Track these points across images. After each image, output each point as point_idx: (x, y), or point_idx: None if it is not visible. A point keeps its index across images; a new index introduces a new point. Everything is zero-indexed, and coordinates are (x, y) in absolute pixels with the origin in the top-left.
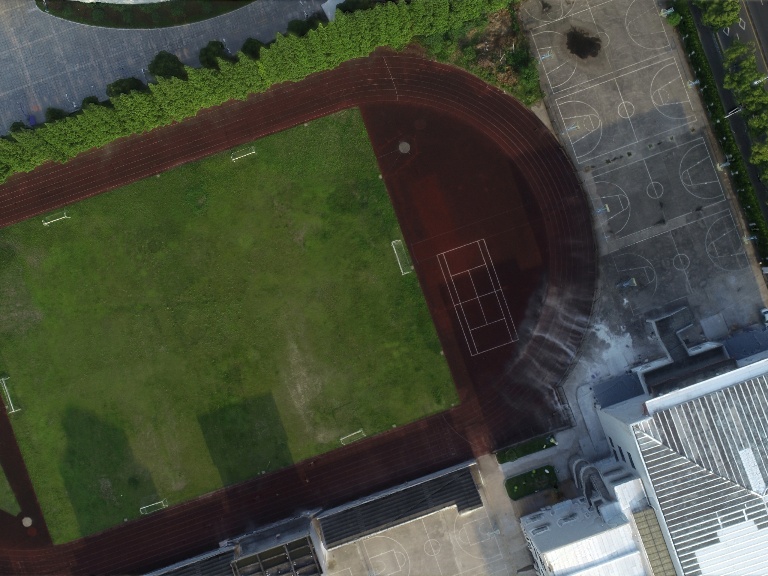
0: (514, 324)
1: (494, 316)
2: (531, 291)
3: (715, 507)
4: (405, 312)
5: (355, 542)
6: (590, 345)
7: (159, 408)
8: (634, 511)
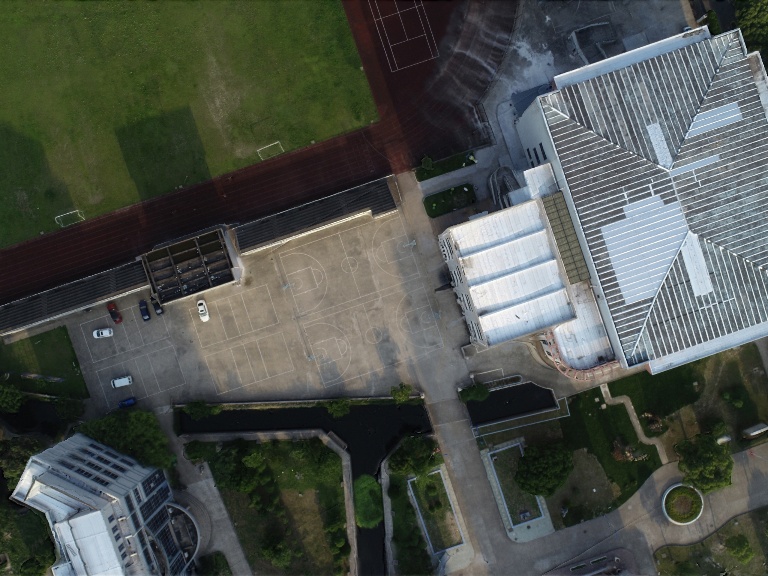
0: (435, 40)
1: (415, 32)
2: (452, 7)
3: (622, 182)
4: (325, 26)
5: (272, 259)
6: (511, 63)
7: (76, 120)
8: (543, 197)
